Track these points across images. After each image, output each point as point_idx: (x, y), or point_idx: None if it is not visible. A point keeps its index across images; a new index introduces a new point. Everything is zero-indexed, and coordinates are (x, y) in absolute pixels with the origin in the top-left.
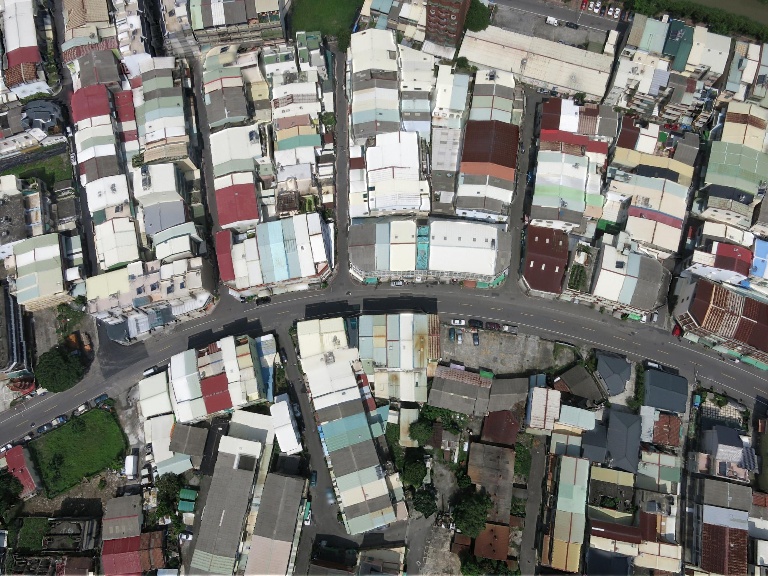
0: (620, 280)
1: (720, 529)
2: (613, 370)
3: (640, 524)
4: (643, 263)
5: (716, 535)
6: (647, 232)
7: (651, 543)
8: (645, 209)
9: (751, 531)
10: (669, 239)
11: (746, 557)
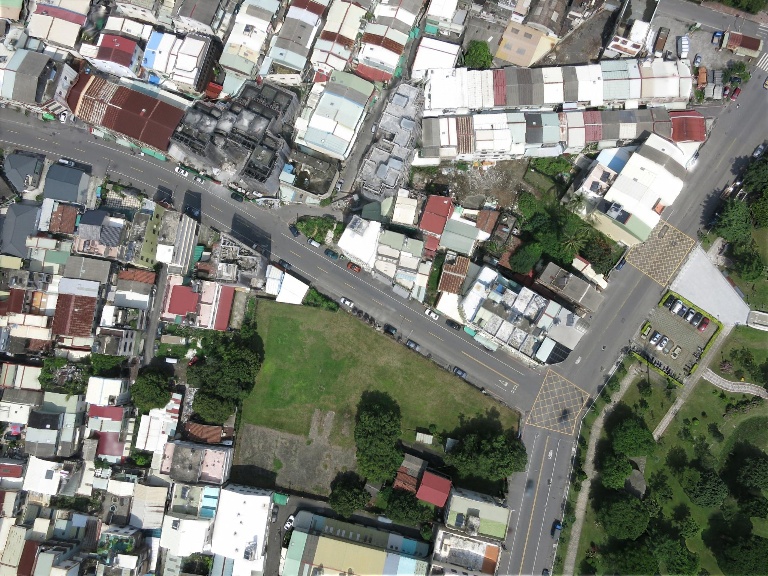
0: (1, 75)
1: (68, 297)
2: (12, 165)
3: (8, 299)
4: (27, 58)
5: (65, 302)
6: (44, 28)
7: (18, 315)
8: (48, 6)
9: (120, 302)
10: (66, 35)
11: (92, 320)
